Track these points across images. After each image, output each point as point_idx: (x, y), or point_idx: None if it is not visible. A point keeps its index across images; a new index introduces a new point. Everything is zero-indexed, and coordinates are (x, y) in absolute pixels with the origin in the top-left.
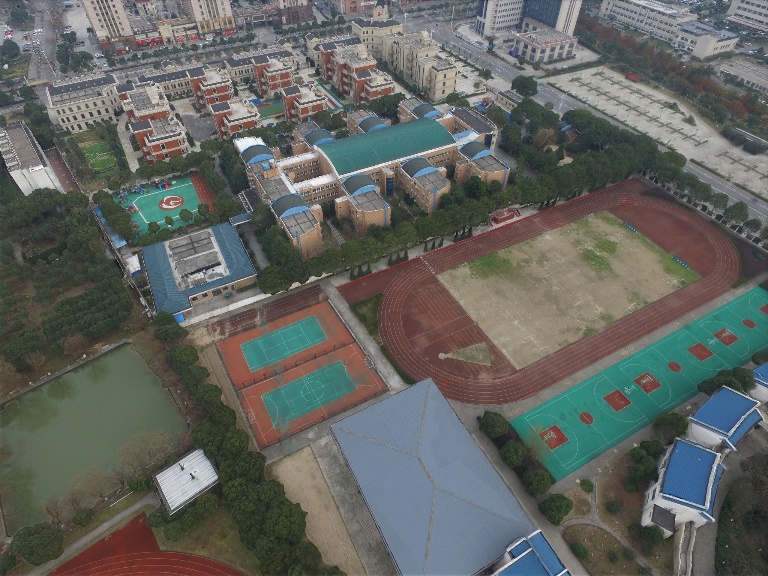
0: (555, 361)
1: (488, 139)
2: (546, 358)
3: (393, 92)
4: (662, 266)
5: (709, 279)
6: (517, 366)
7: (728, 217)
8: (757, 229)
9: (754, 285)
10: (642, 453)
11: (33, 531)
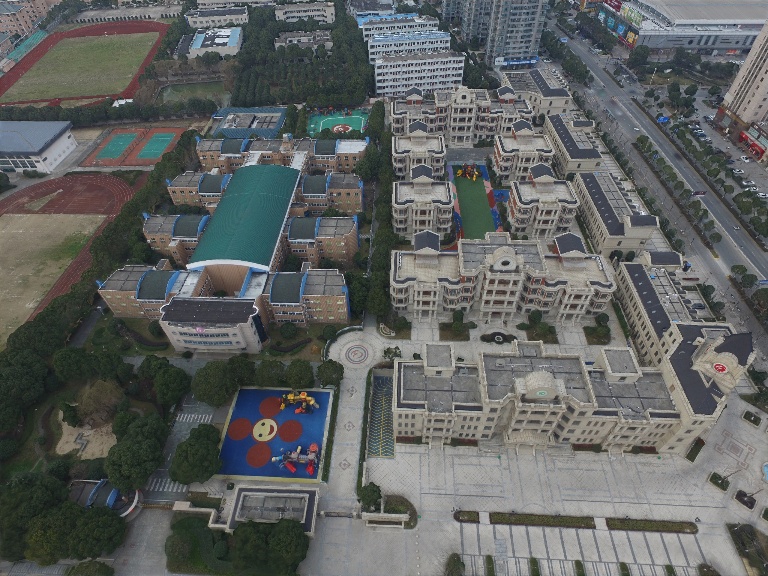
0: None
1: None
2: None
3: (393, 290)
4: None
5: None
6: (6, 215)
7: None
8: None
9: None
10: None
11: None
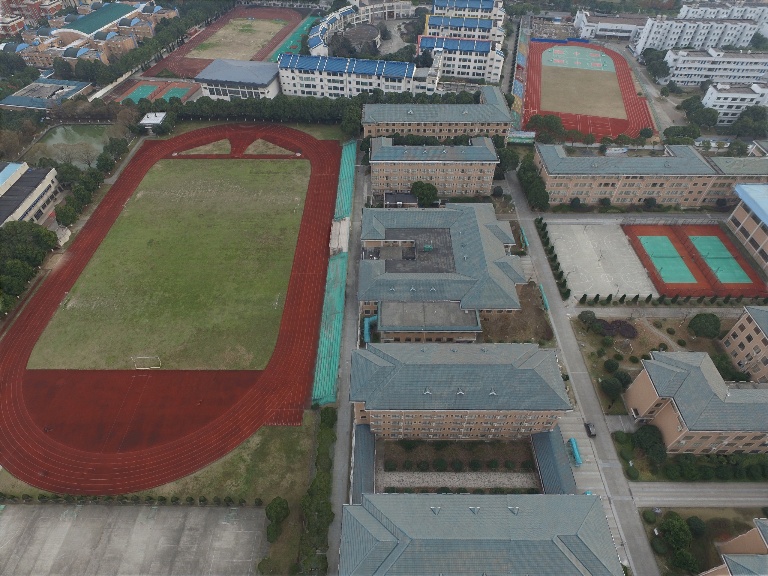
0: (258, 55)
1: (152, 5)
2: (255, 56)
3: (63, 8)
4: (273, 23)
5: (293, 21)
6: None
7: (285, 2)
8: (297, 1)
9: (308, 17)
10: (301, 49)
11: (111, 139)
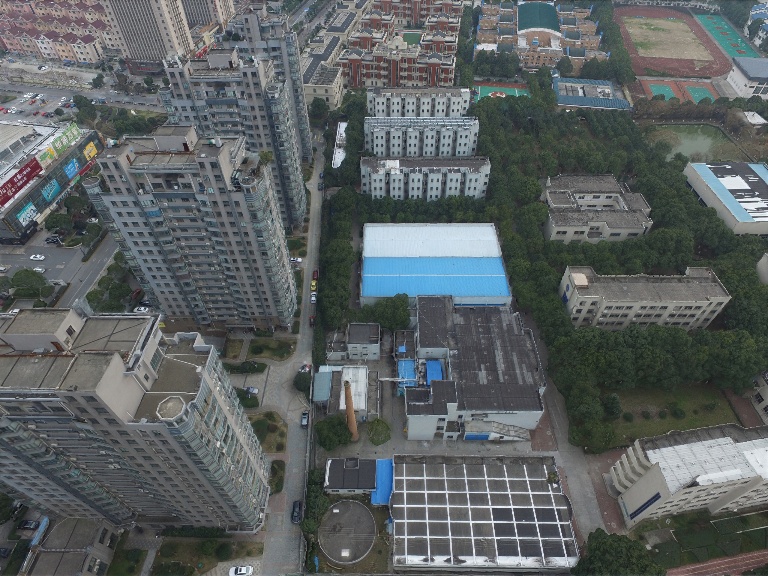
0: None
1: None
2: (711, 54)
3: None
4: None
5: None
6: None
7: (653, 1)
8: None
9: None
10: None
11: None
